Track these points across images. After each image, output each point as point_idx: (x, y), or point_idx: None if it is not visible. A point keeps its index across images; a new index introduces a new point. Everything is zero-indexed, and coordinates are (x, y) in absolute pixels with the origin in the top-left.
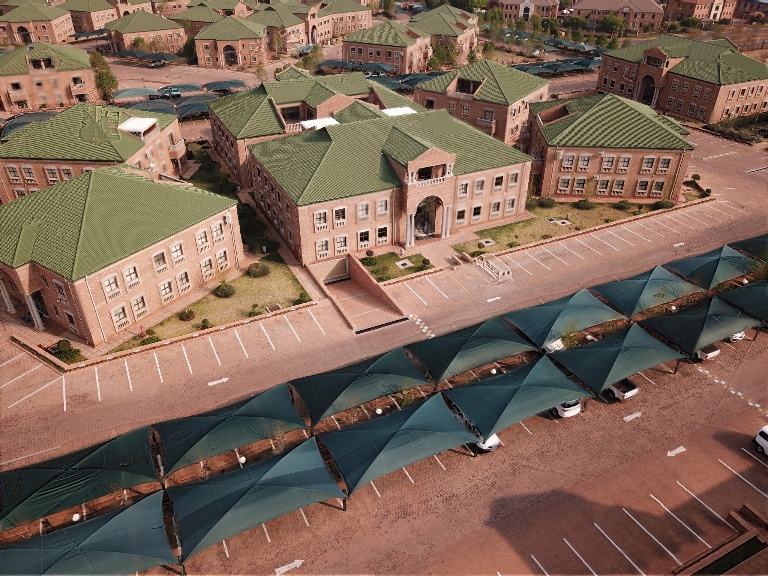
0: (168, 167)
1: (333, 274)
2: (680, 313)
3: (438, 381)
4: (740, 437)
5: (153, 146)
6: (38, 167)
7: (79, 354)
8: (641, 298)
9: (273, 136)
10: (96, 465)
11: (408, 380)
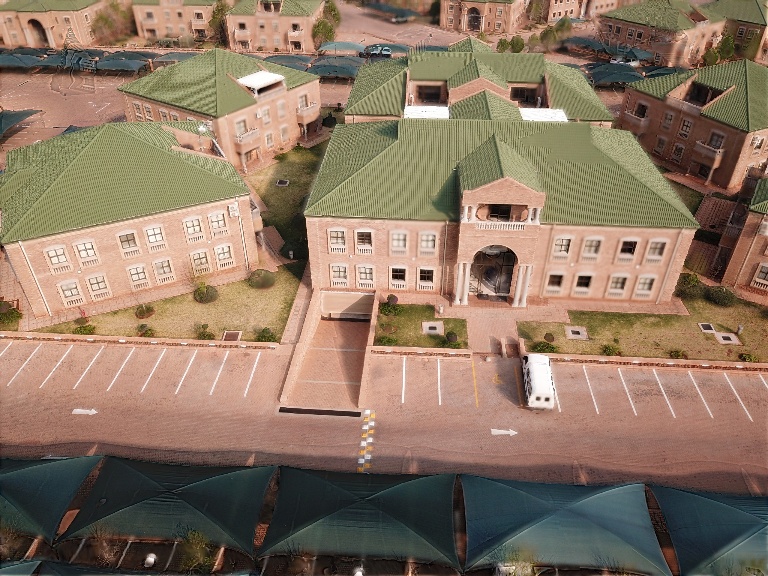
0: (292, 131)
1: (355, 309)
2: None
3: (261, 553)
4: None
5: (272, 106)
6: (155, 108)
7: (18, 320)
8: (728, 555)
9: (389, 118)
10: None
11: (217, 532)
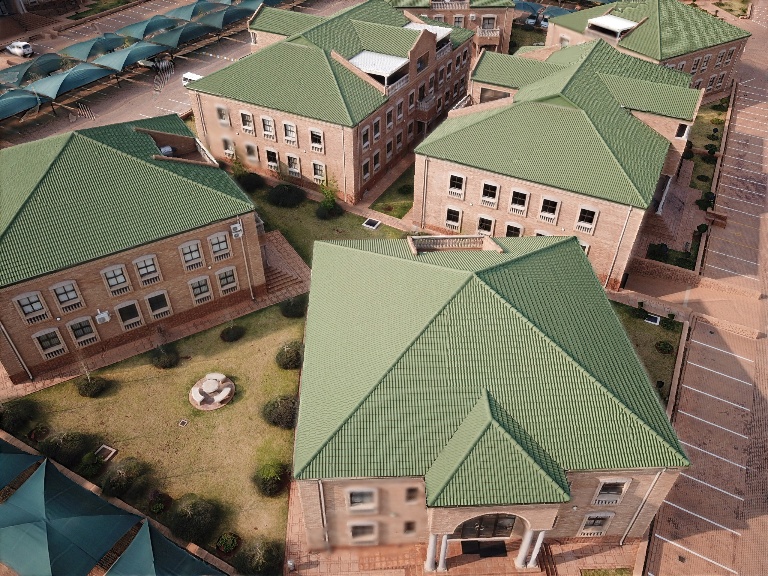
0: None
1: None
2: (53, 63)
3: None
4: None
5: None
6: None
7: None
8: None
9: None
10: None
11: None
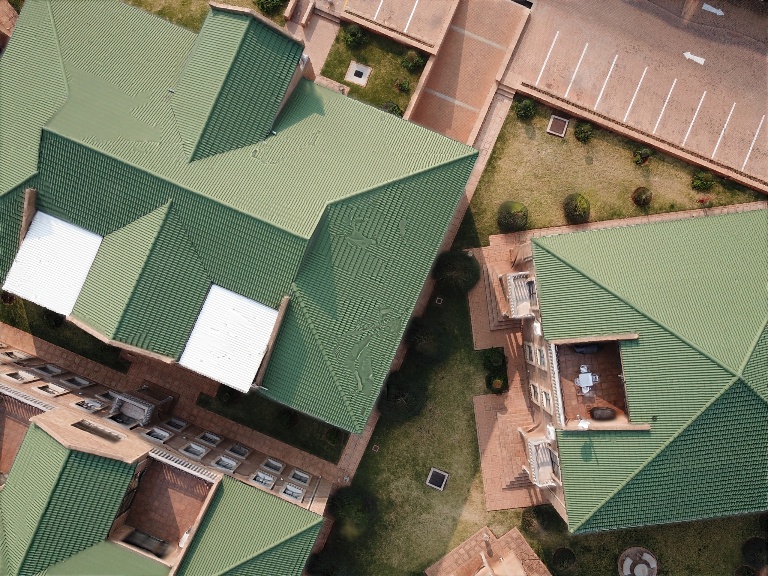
0: None
1: None
2: None
3: None
4: None
5: None
6: None
7: None
8: None
9: None
10: None
11: None
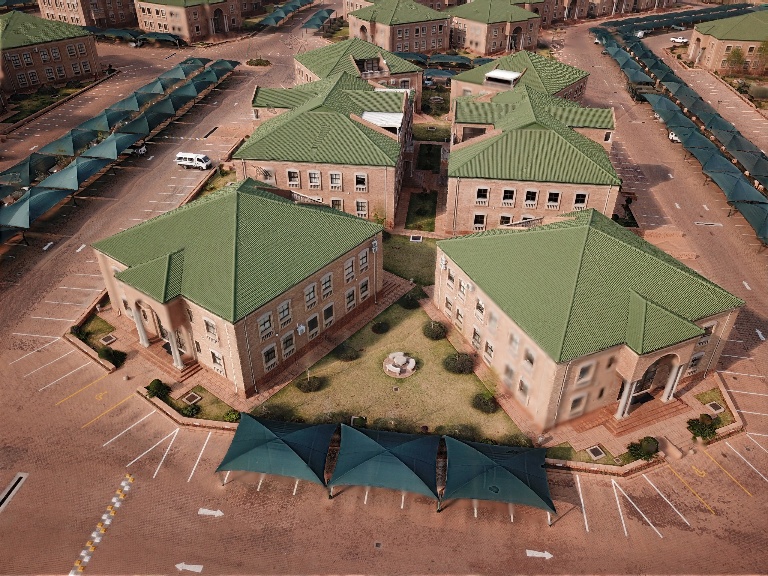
0: None
1: None
2: (48, 160)
3: None
4: (5, 160)
5: None
6: None
7: None
8: None
9: None
10: (208, 72)
11: None
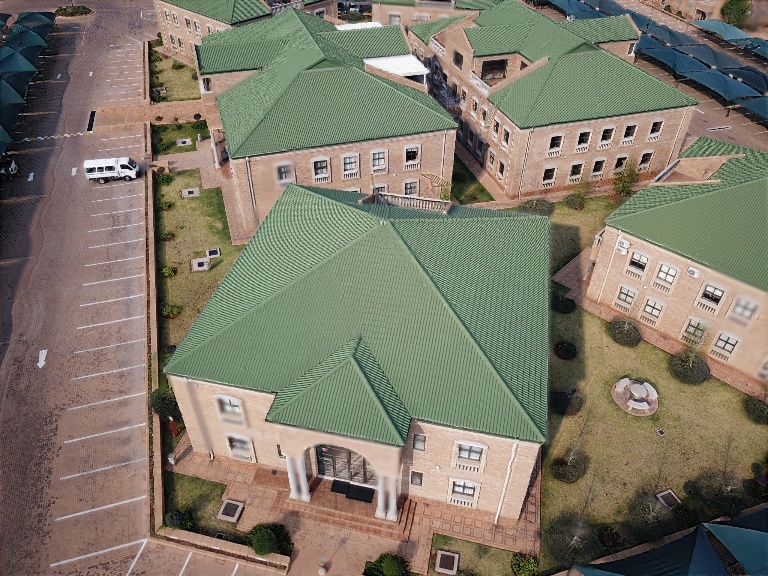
0: None
1: None
2: None
3: None
4: None
5: (433, 16)
6: None
7: (162, 45)
8: None
9: None
10: (24, 33)
11: None
